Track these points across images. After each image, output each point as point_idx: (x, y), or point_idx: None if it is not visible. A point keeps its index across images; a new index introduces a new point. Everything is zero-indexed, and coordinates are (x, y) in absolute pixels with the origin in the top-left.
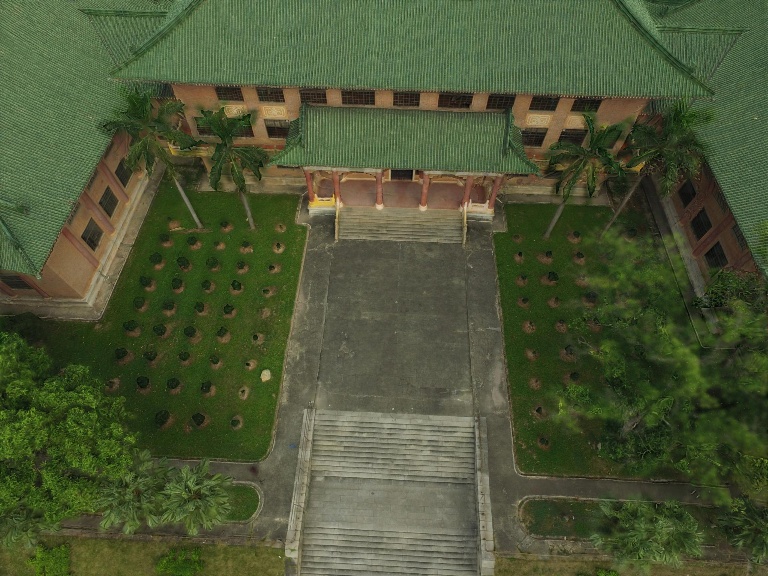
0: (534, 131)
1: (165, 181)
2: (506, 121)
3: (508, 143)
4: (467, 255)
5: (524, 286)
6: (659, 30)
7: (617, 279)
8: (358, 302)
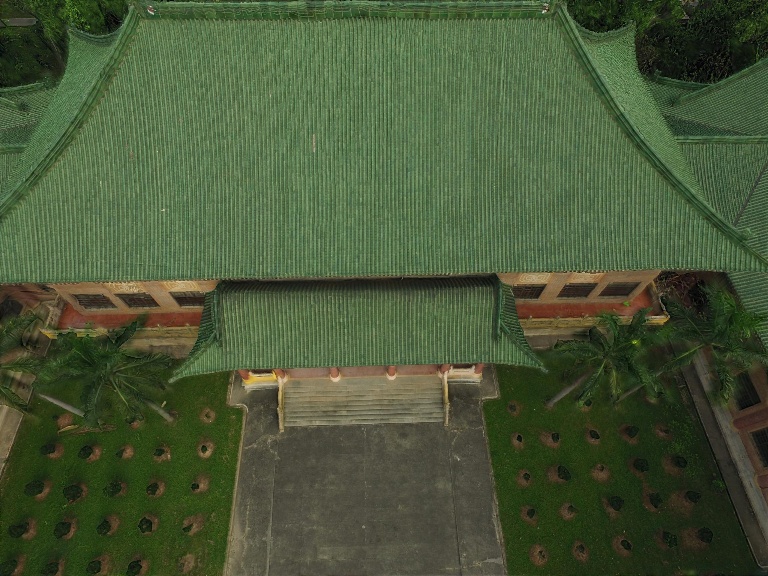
0: (529, 286)
1: (54, 348)
2: (494, 297)
3: (499, 328)
4: (451, 440)
5: (527, 486)
6: (679, 142)
7: (644, 470)
8: (313, 531)
